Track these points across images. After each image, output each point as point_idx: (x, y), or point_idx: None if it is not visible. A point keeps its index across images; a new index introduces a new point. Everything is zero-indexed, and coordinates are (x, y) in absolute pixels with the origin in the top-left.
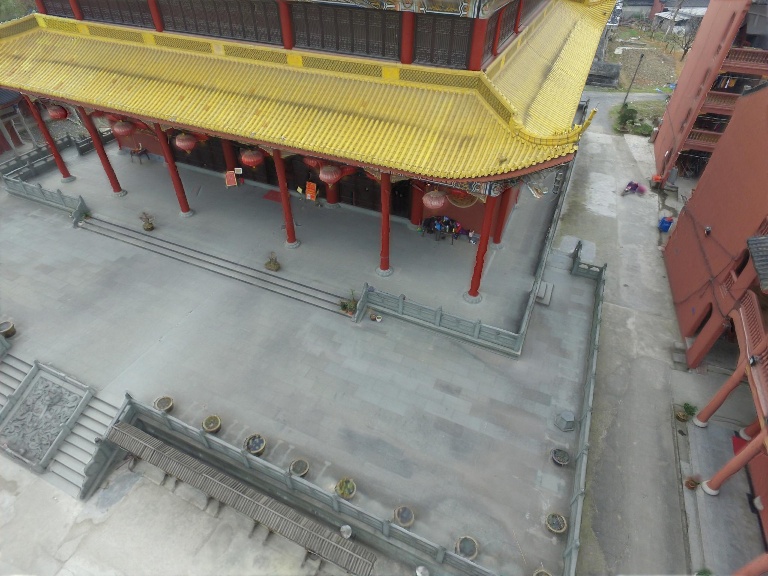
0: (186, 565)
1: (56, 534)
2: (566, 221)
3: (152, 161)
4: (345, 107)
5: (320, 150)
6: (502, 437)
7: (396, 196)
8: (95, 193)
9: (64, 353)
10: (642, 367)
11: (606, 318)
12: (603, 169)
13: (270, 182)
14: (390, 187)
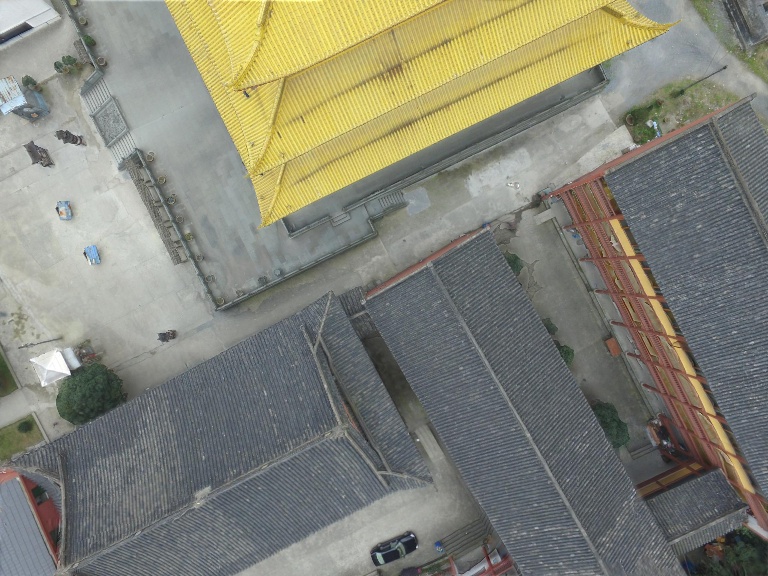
0: (142, 217)
1: (109, 177)
2: (440, 177)
3: None
4: None
5: None
6: (253, 260)
7: None
8: None
9: (123, 95)
10: (351, 277)
11: (369, 247)
12: (537, 151)
13: None
14: None
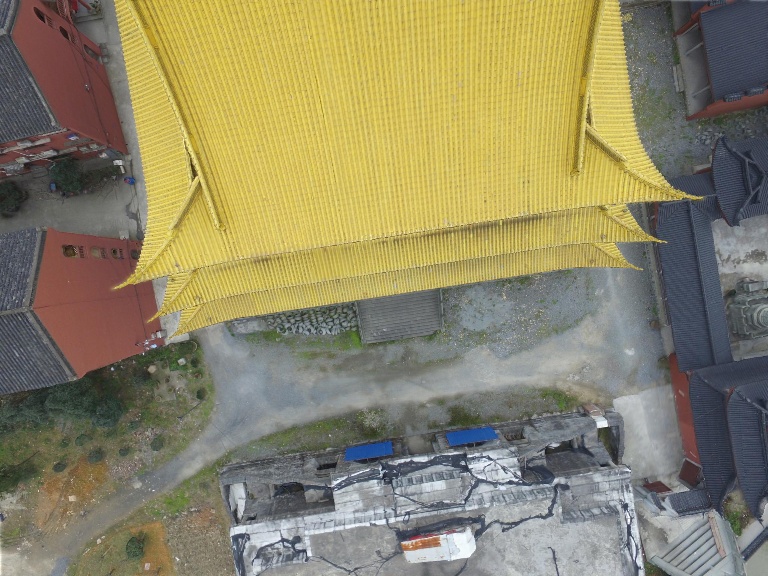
0: None
1: None
2: None
3: None
4: None
5: None
6: None
7: None
8: None
9: None
10: None
11: None
12: None
13: None
14: None
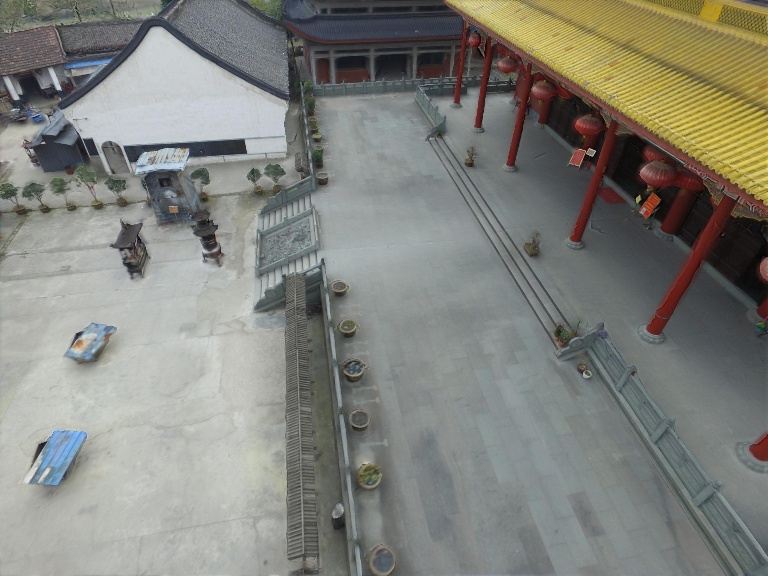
0: (247, 405)
1: (226, 316)
2: None
3: (529, 117)
4: (730, 81)
5: (643, 121)
6: None
7: (759, 263)
8: (462, 122)
9: (333, 213)
10: None
11: None
12: None
13: (615, 178)
14: (725, 222)
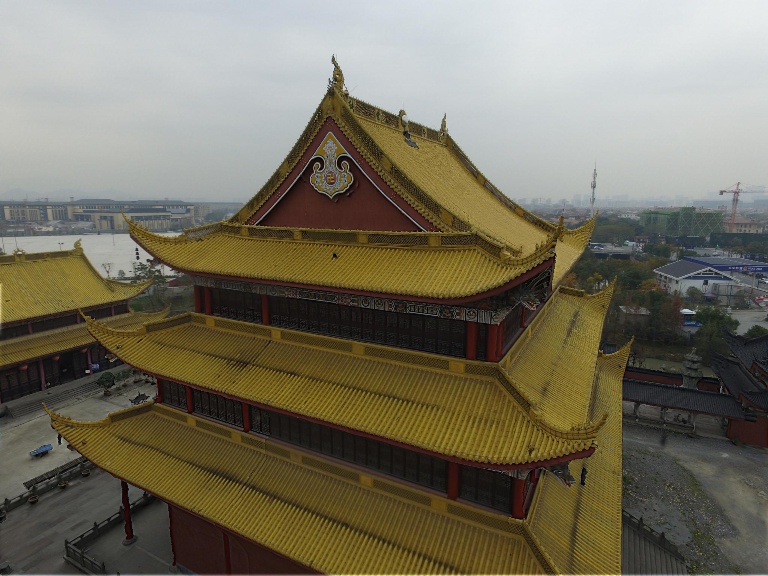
0: None
1: None
2: None
3: None
4: None
5: None
6: None
7: None
8: None
9: None
10: None
11: None
12: None
13: None
14: None
